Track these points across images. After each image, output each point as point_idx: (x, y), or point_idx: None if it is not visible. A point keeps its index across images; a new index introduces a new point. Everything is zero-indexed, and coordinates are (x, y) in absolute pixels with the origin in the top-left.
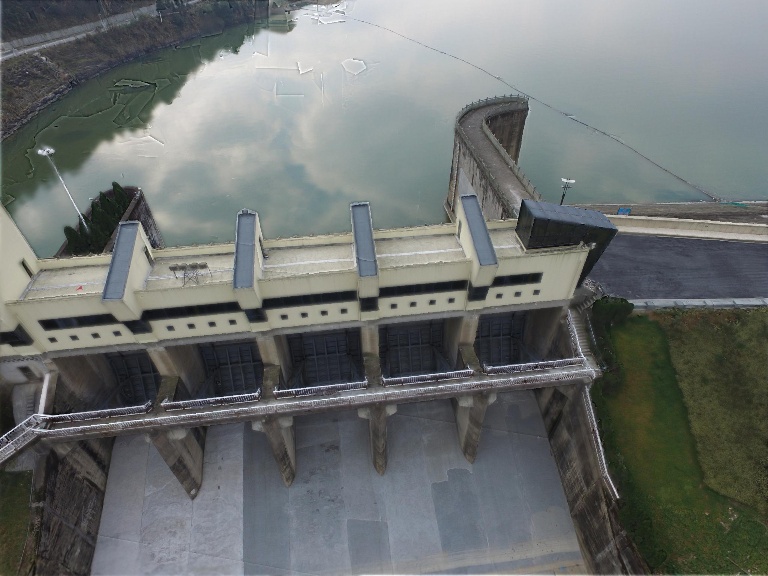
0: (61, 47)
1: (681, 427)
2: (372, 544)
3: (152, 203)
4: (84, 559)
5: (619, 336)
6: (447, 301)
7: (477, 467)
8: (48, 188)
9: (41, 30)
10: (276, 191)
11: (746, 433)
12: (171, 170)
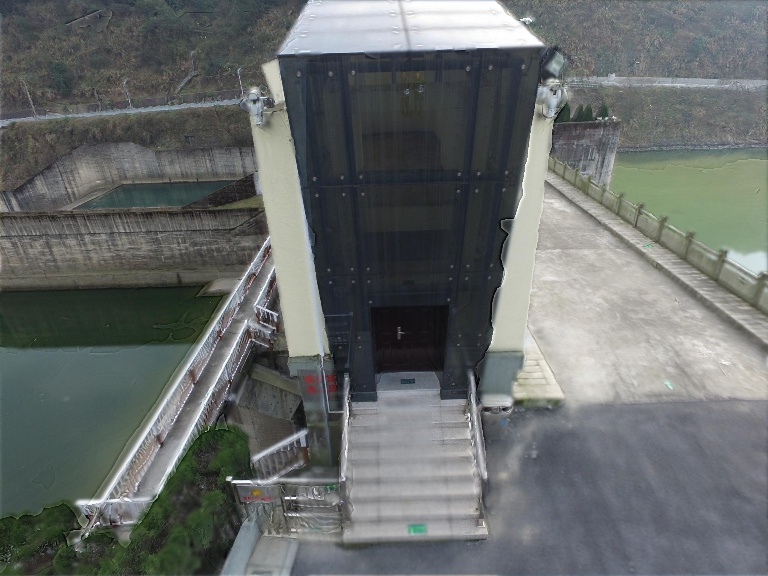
0: None
1: None
2: None
3: (723, 213)
4: None
5: None
6: None
7: None
8: (690, 174)
9: None
10: None
11: None
12: None
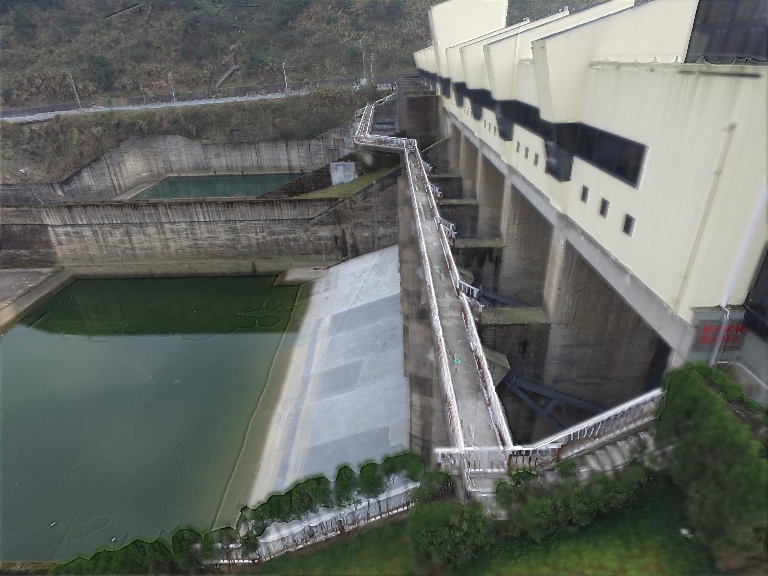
0: None
1: None
2: (337, 382)
3: None
4: (365, 244)
5: (636, 563)
6: (545, 166)
7: (404, 484)
8: None
9: None
10: None
11: None
12: None
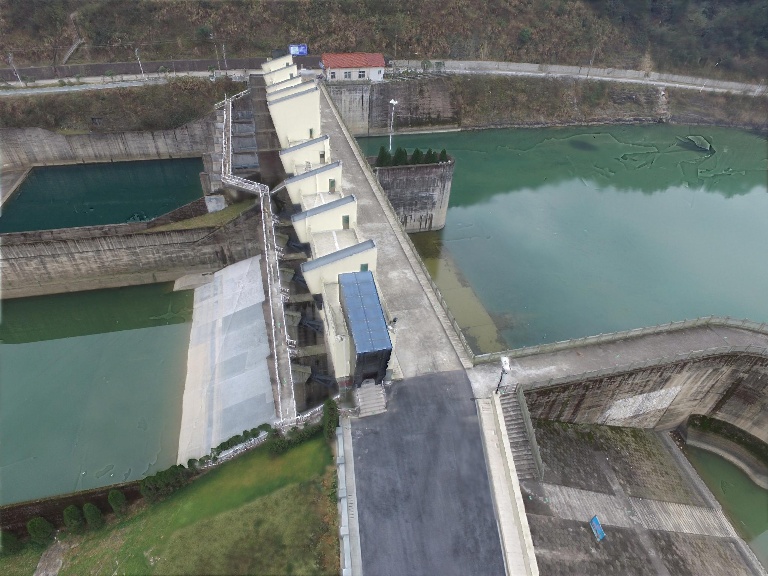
0: (690, 91)
1: (228, 509)
2: (233, 368)
3: (520, 201)
4: (239, 255)
5: (315, 444)
6: None
7: None
8: (511, 159)
9: (699, 74)
10: (583, 259)
11: (206, 571)
12: (572, 197)
